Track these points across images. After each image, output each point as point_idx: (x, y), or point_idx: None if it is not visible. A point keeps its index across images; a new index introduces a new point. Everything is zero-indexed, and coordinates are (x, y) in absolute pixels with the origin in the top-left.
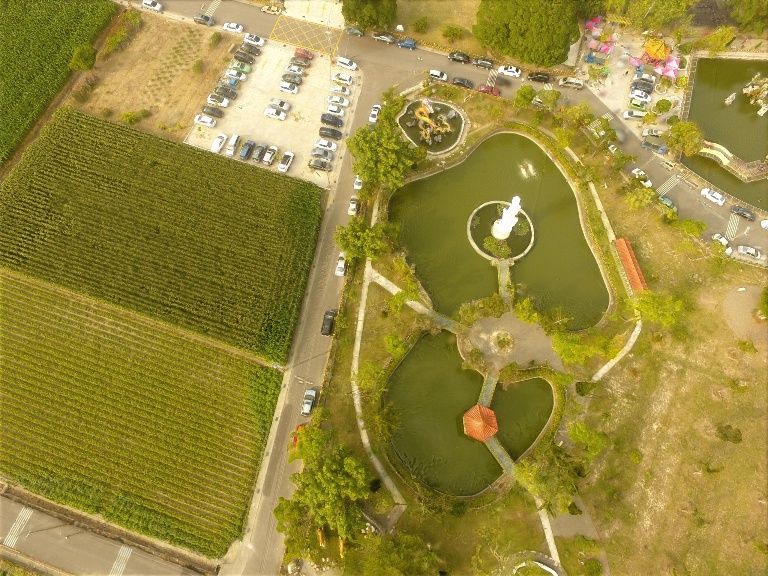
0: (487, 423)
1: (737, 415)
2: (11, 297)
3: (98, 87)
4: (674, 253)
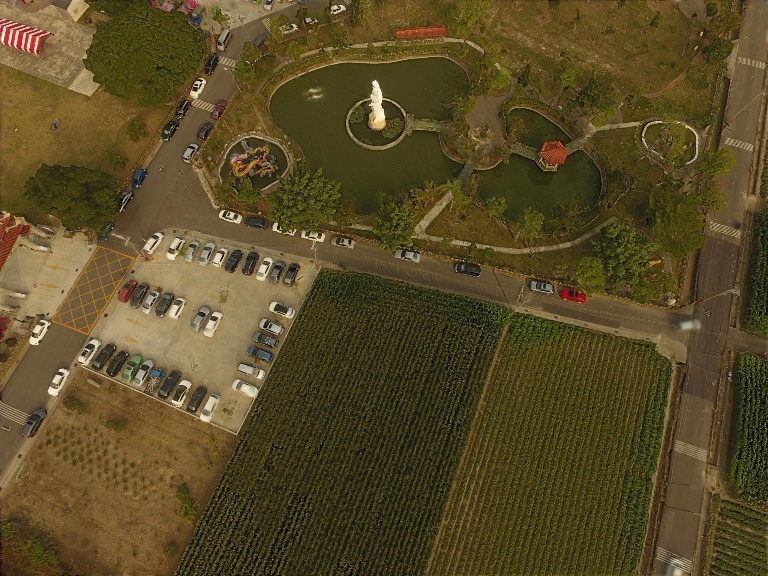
0: None
1: (532, 0)
2: None
3: (120, 573)
4: (406, 6)
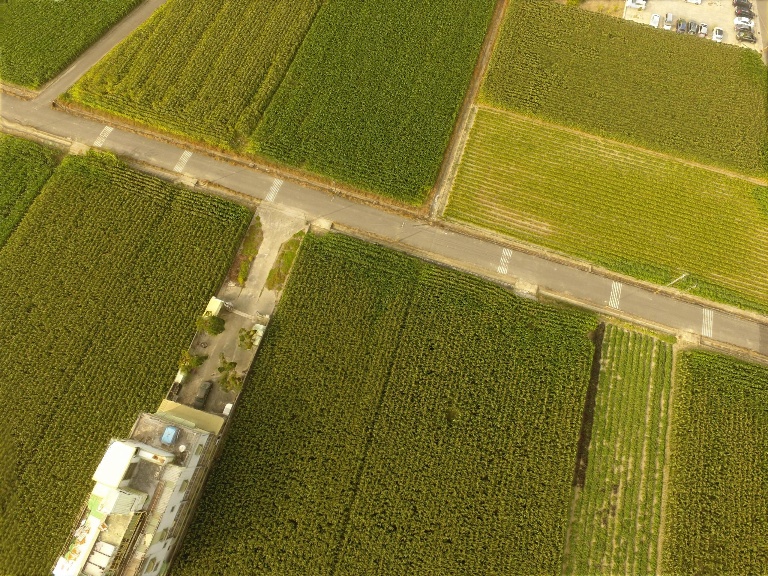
0: None
1: None
2: (532, 134)
3: None
4: None
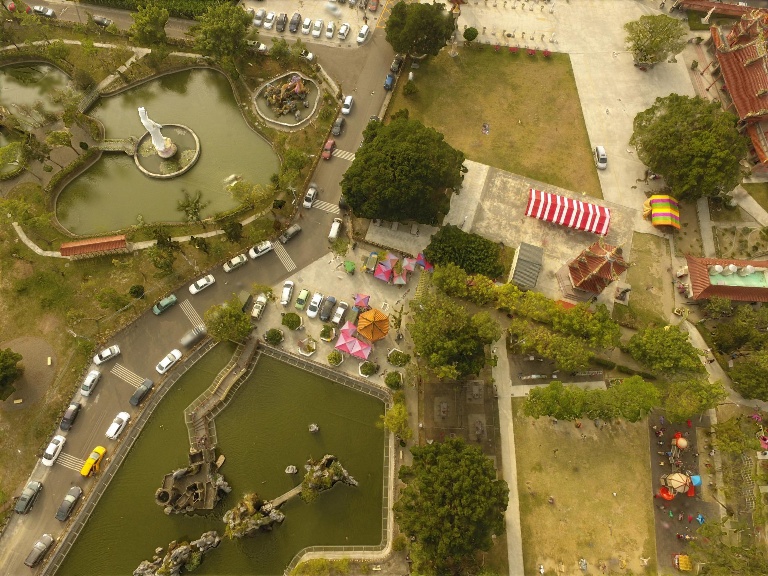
0: None
1: None
2: None
3: None
4: None
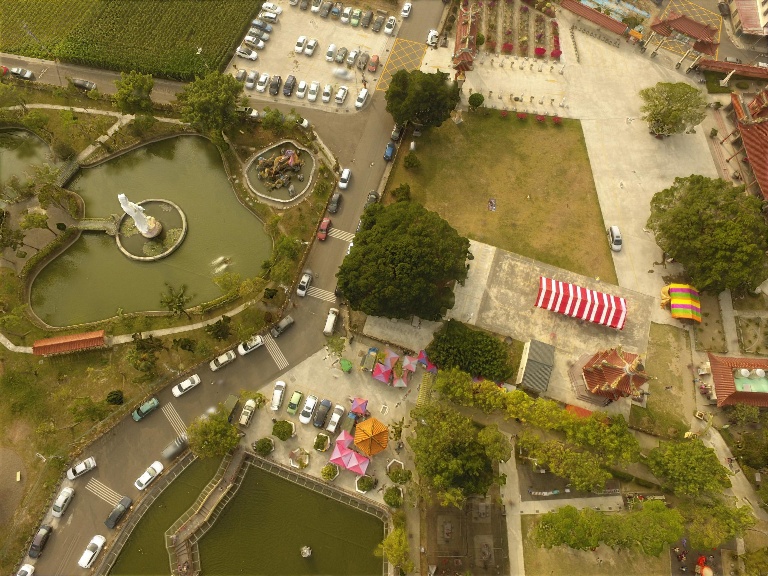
0: None
1: None
2: None
3: None
4: None
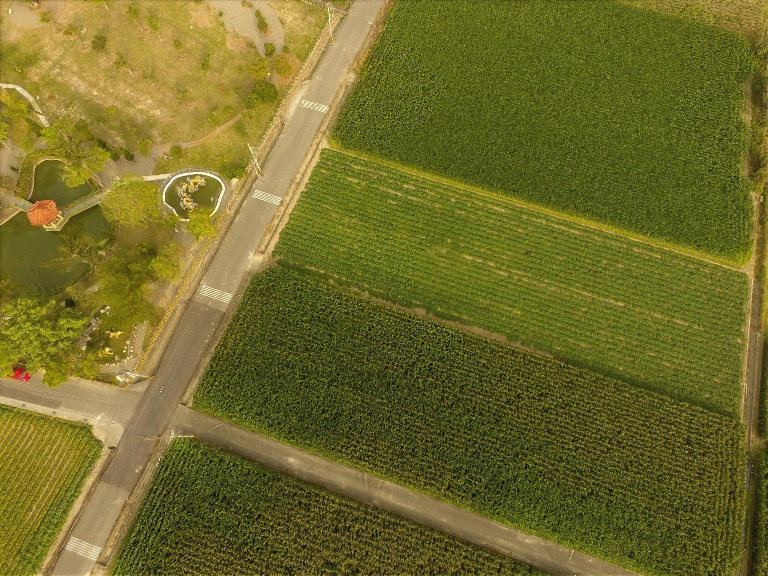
0: (42, 207)
1: None
2: None
3: None
4: None
